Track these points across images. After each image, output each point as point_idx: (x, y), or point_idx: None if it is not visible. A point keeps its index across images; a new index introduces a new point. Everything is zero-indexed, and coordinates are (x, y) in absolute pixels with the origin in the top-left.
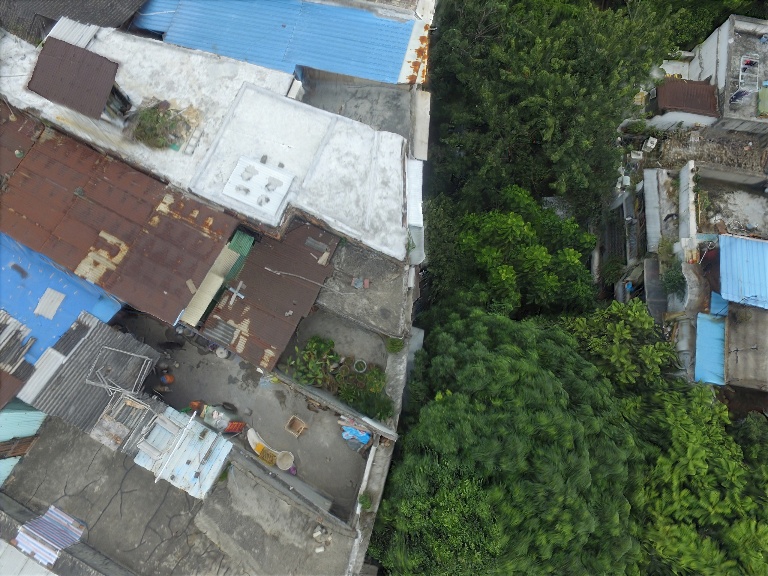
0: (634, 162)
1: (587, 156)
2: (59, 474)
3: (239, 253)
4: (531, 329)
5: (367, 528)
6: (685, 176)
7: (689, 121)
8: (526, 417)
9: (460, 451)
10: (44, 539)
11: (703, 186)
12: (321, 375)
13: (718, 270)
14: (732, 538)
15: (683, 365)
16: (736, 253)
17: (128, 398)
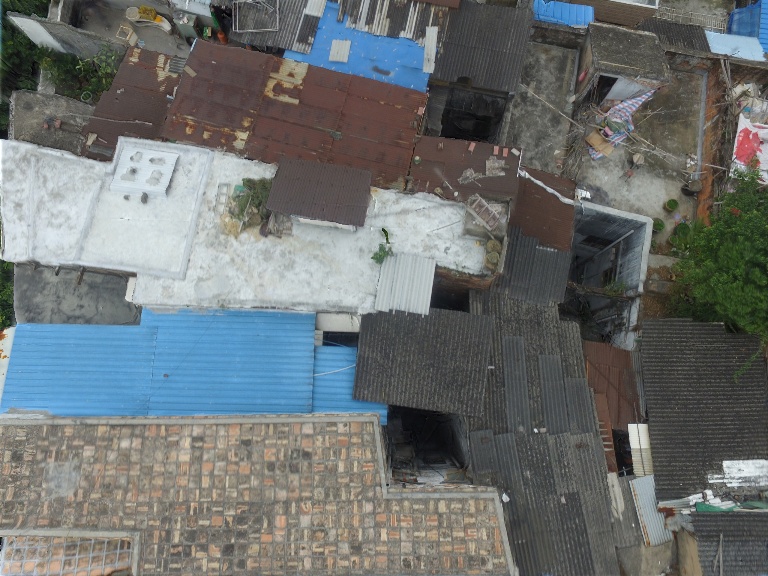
0: None
1: None
2: None
3: None
4: None
5: None
6: None
7: None
8: None
9: None
10: None
11: None
12: (95, 61)
13: None
14: None
15: None
16: None
17: None
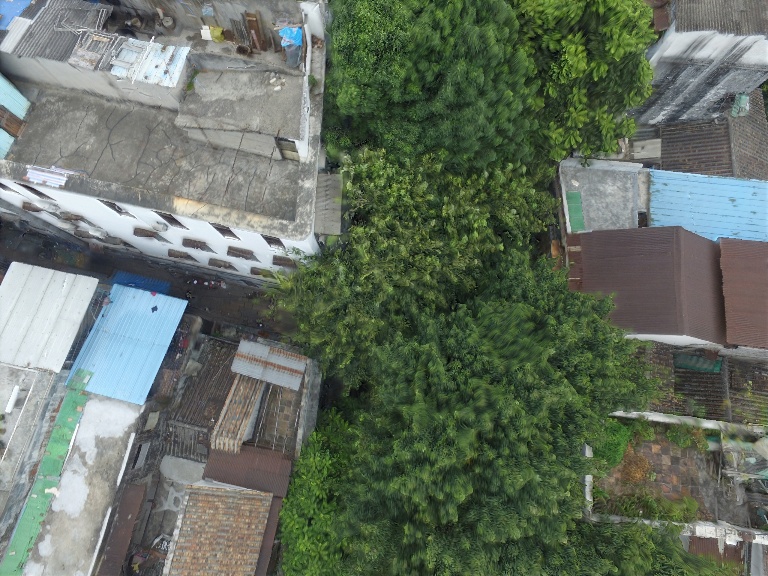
0: None
1: None
2: (52, 145)
3: None
4: None
5: (318, 105)
6: None
7: None
8: None
9: None
10: (51, 170)
11: None
12: None
13: None
14: None
15: None
16: None
17: (94, 35)
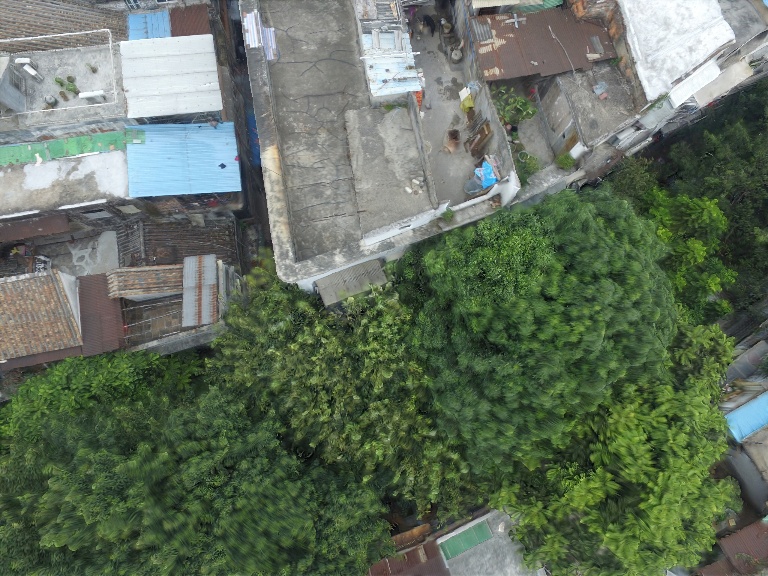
0: None
1: None
2: (294, 18)
3: (543, 2)
4: None
5: (428, 232)
6: None
7: None
8: None
9: (558, 228)
10: (260, 31)
11: None
12: None
13: None
14: (671, 460)
15: None
16: None
17: (395, 3)
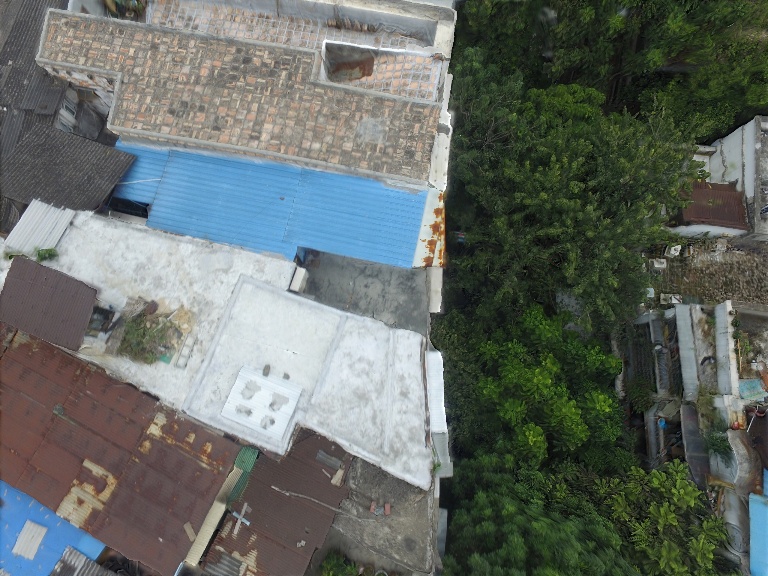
0: (657, 269)
1: None
2: None
3: (242, 469)
4: (572, 544)
5: None
6: (722, 316)
7: (716, 231)
8: None
9: None
10: None
11: (741, 323)
12: None
13: None
14: None
15: (733, 542)
16: None
17: None
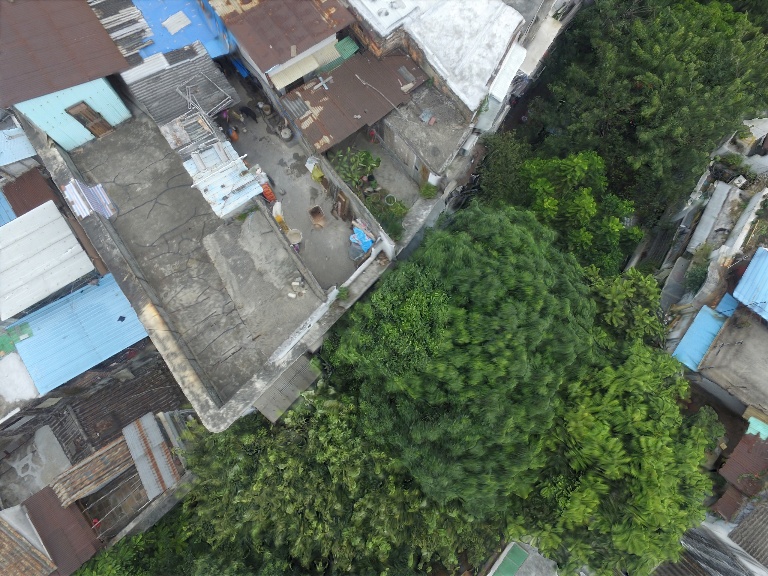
0: None
1: (673, 155)
2: (116, 165)
3: (341, 54)
4: None
5: (333, 317)
6: (755, 200)
7: None
8: (512, 270)
9: (443, 272)
10: (86, 197)
11: (767, 219)
12: None
13: (742, 272)
14: (636, 444)
15: None
16: (766, 267)
17: (201, 118)
